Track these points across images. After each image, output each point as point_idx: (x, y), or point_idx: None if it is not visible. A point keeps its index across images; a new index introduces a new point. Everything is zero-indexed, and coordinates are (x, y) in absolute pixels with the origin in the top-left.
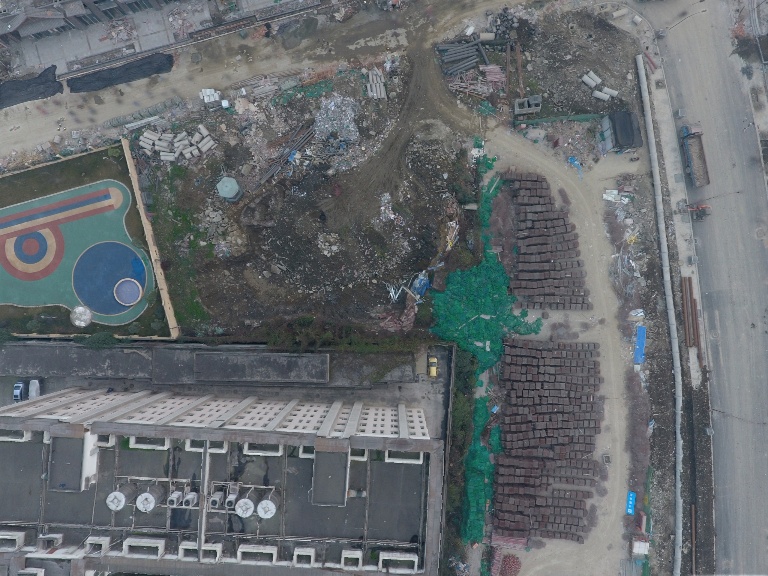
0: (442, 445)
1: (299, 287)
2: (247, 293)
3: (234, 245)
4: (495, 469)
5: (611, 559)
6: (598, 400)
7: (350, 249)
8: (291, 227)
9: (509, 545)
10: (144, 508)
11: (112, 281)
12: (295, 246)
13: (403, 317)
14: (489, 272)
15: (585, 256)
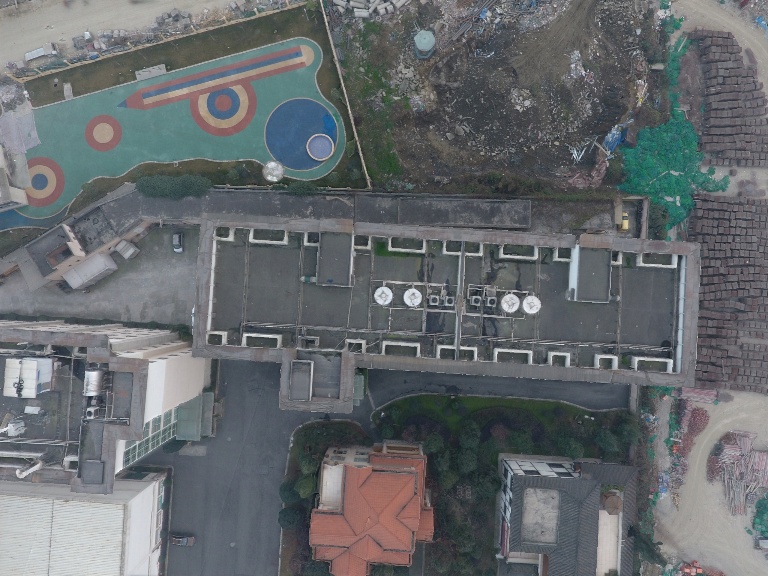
0: (699, 247)
1: (481, 150)
2: (432, 153)
3: (427, 100)
4: None
5: None
6: None
7: (540, 106)
8: (484, 82)
9: (699, 397)
10: (411, 303)
11: (304, 137)
12: (487, 102)
13: (594, 172)
14: (680, 127)
15: None
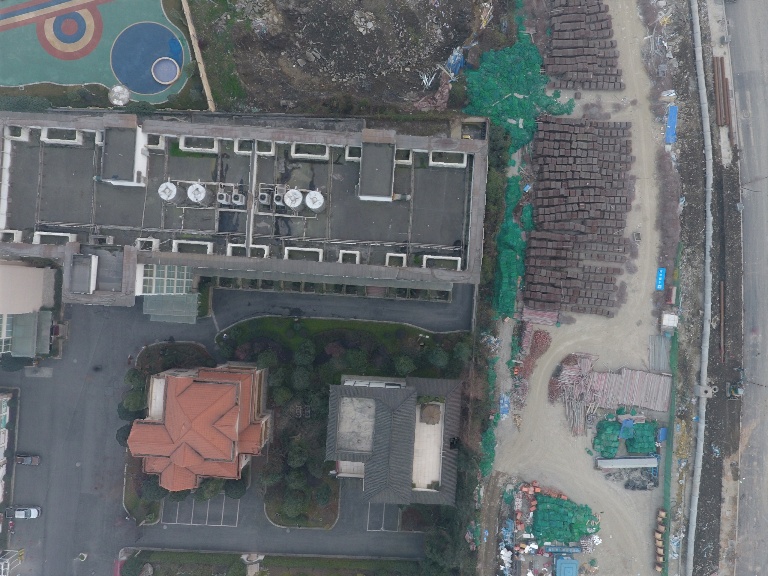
0: (486, 144)
1: (333, 76)
2: (282, 78)
3: (270, 23)
4: (527, 245)
5: (640, 335)
6: (629, 179)
7: (385, 29)
8: (327, 4)
9: (540, 319)
10: (195, 198)
11: (150, 61)
12: (331, 24)
13: (437, 95)
14: (523, 49)
15: (618, 38)
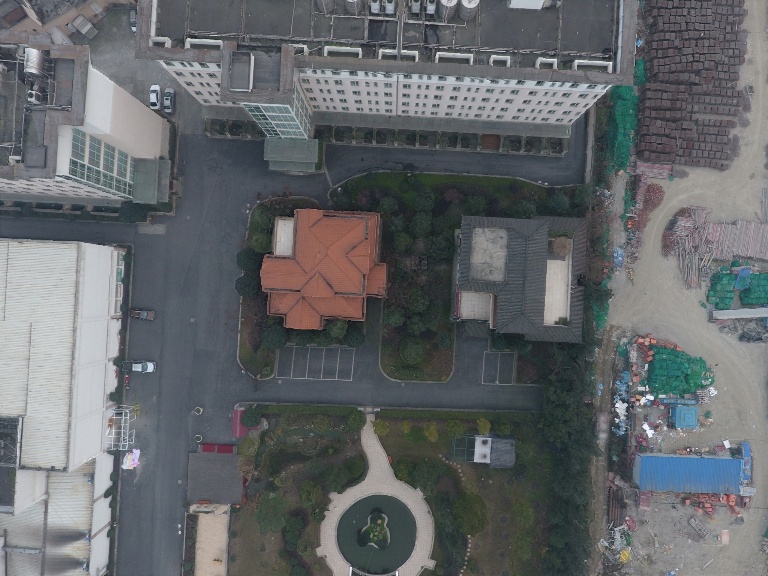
0: None
1: None
2: None
3: None
4: (640, 99)
5: (753, 188)
6: (741, 32)
7: None
8: None
9: (654, 172)
10: None
11: None
12: None
13: None
14: None
15: None
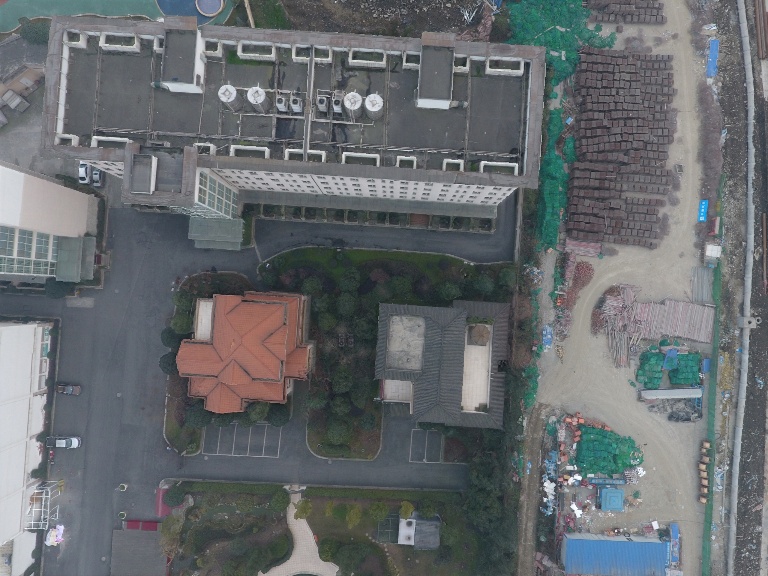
0: (544, 50)
1: (374, 12)
2: (324, 13)
3: None
4: (569, 177)
5: (683, 267)
6: (671, 111)
7: None
8: None
9: (583, 250)
10: (255, 101)
11: None
12: None
13: (480, 27)
14: None
15: None
